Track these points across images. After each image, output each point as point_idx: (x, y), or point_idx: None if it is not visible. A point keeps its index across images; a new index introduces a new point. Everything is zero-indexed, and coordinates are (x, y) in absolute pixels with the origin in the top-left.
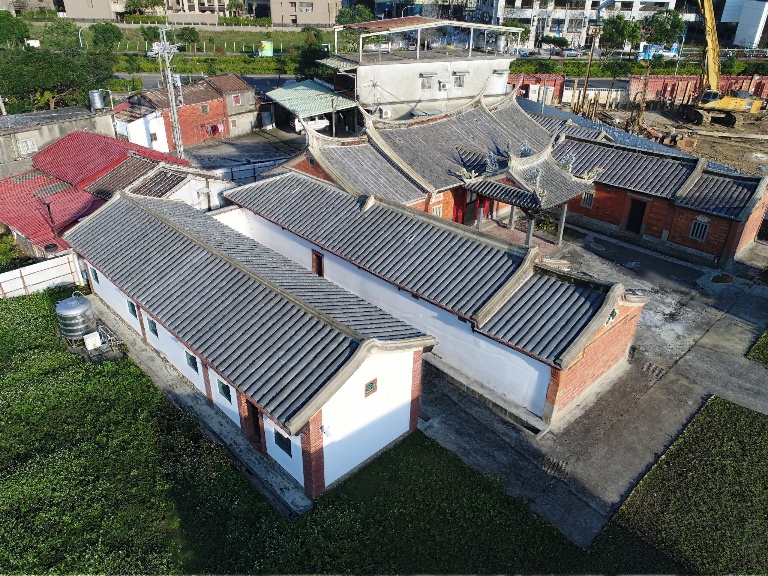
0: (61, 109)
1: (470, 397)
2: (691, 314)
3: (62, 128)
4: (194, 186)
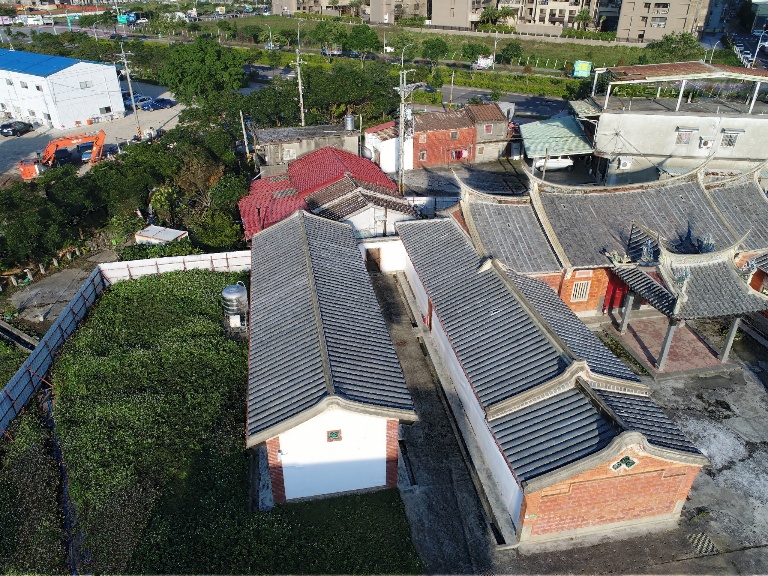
0: (327, 126)
1: (470, 482)
2: None
3: (317, 143)
4: (373, 213)
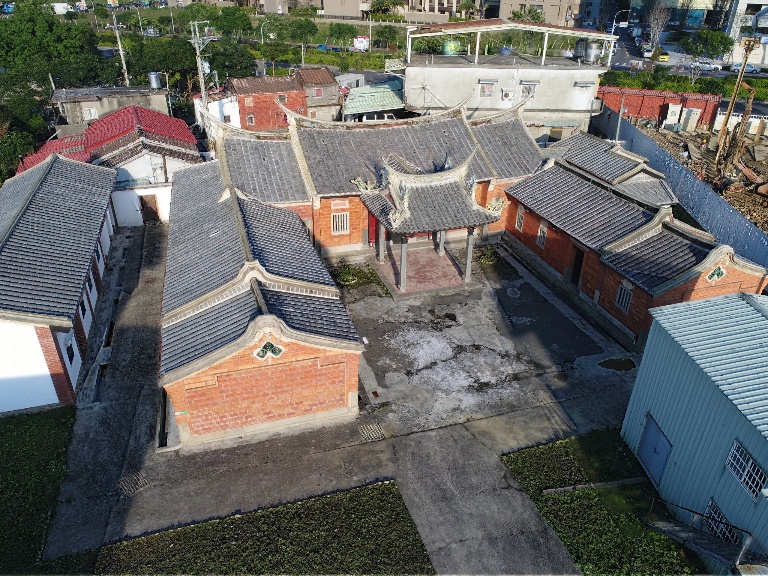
0: (136, 87)
1: (158, 395)
2: (510, 391)
3: (120, 102)
4: (149, 160)
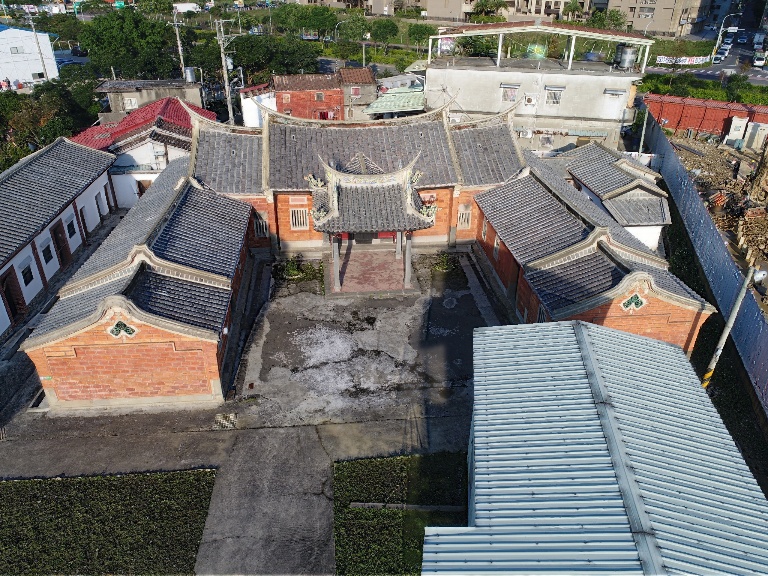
0: (178, 80)
1: None
2: (383, 400)
3: (158, 93)
4: (152, 148)
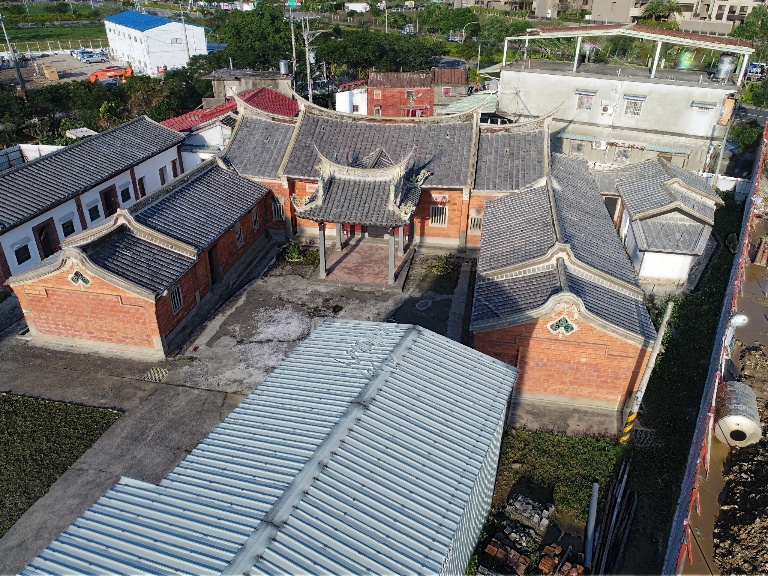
0: None
1: None
2: None
3: (255, 83)
4: (220, 131)
